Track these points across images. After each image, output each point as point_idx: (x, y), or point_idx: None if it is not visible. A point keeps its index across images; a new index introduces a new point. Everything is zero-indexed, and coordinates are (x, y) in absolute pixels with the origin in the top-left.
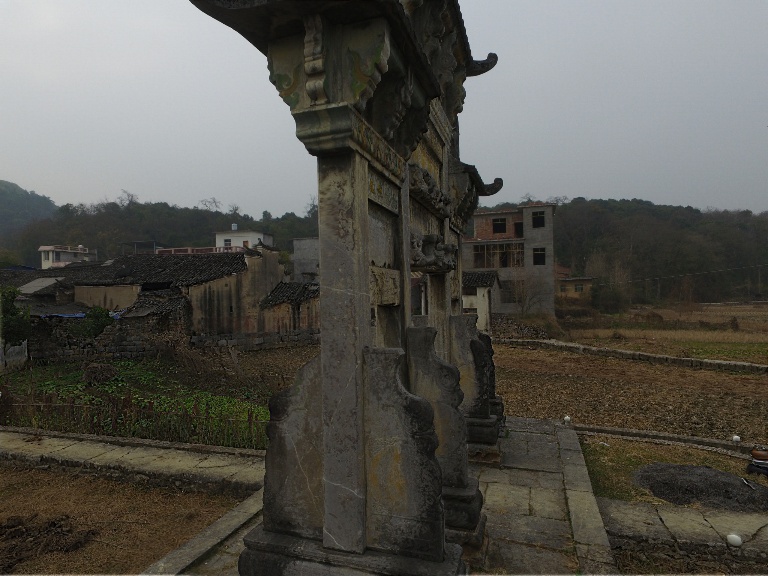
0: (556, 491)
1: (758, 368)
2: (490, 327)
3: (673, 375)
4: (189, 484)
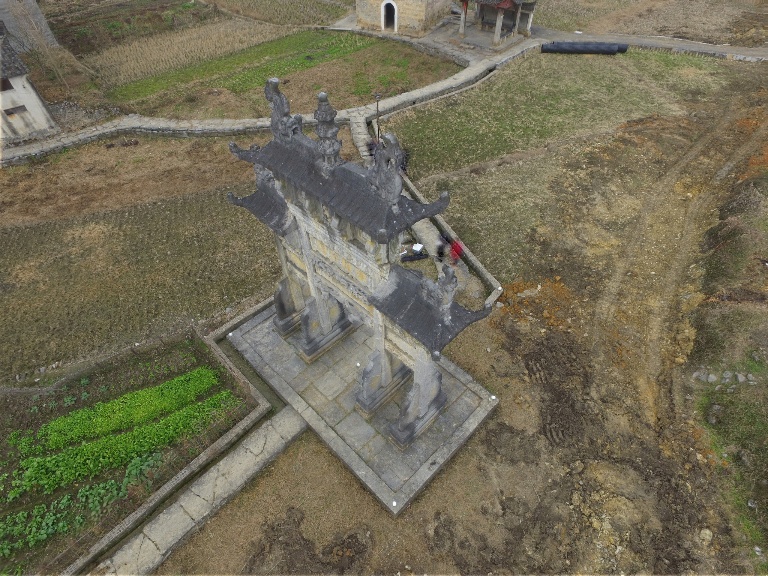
0: None
1: (312, 126)
2: (54, 122)
3: None
4: None
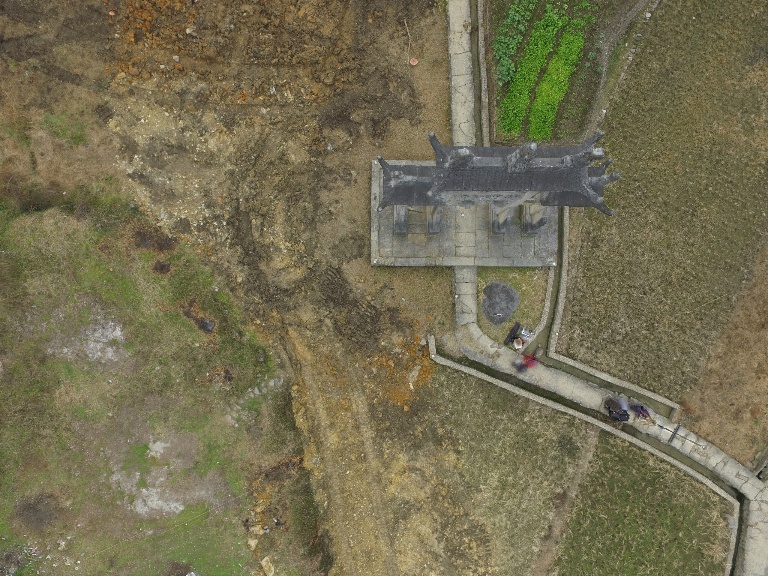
0: (474, 254)
1: None
2: None
3: (762, 365)
4: (452, 128)
